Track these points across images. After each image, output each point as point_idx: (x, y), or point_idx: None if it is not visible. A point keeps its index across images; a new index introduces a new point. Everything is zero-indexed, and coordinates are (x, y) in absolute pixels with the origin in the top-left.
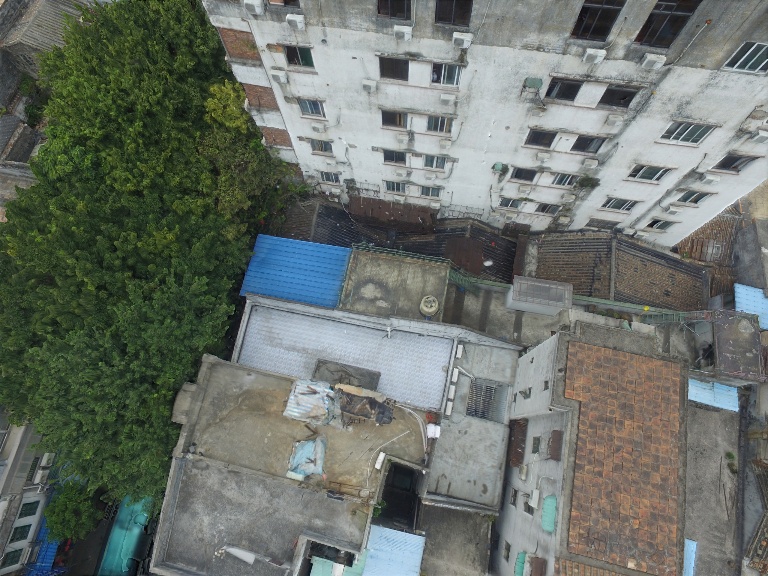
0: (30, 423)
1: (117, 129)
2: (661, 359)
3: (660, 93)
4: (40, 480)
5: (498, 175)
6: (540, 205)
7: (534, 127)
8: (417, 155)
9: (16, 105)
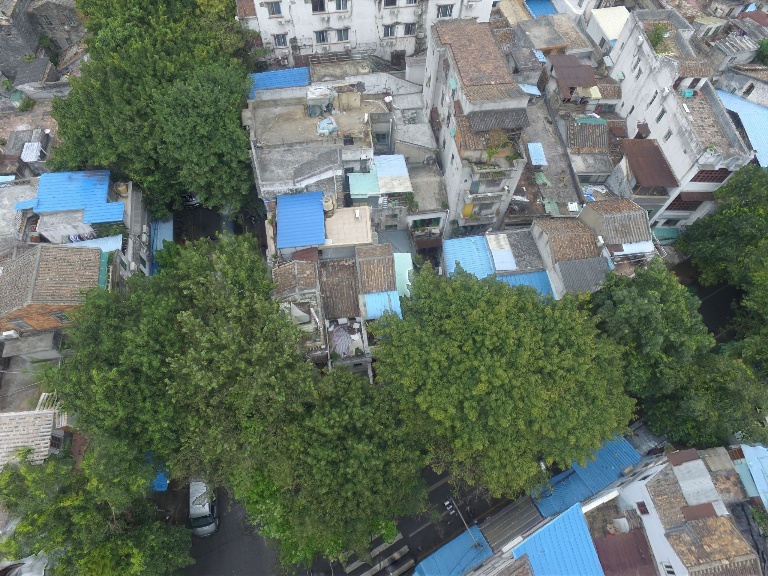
0: (140, 179)
1: (147, 15)
2: None
3: None
4: (146, 239)
5: (377, 4)
6: (406, 29)
7: None
8: (331, 0)
9: (40, 54)
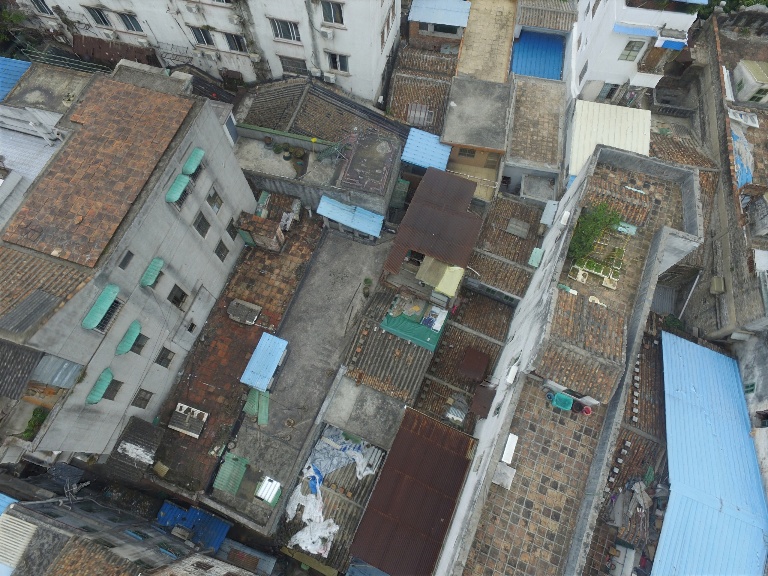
0: None
1: None
2: None
3: None
4: None
5: None
6: (230, 40)
7: None
8: None
9: None
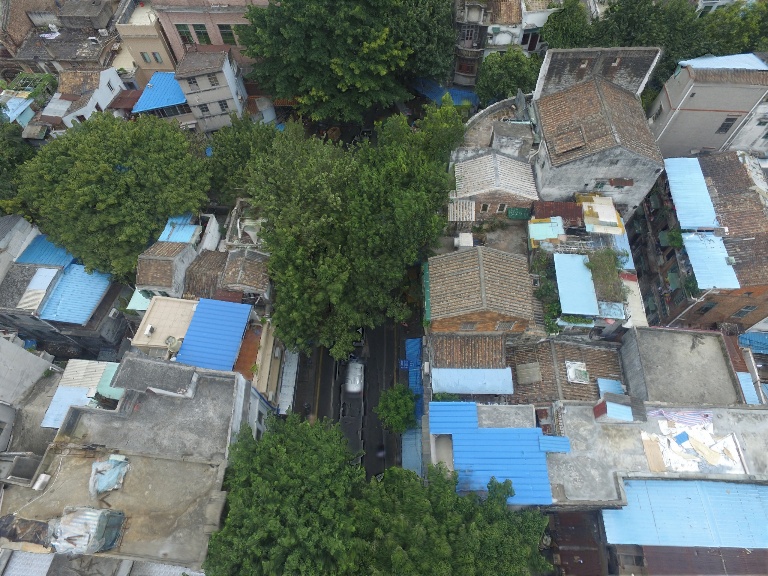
0: None
1: None
2: None
3: None
4: None
5: None
6: None
7: None
8: None
9: None
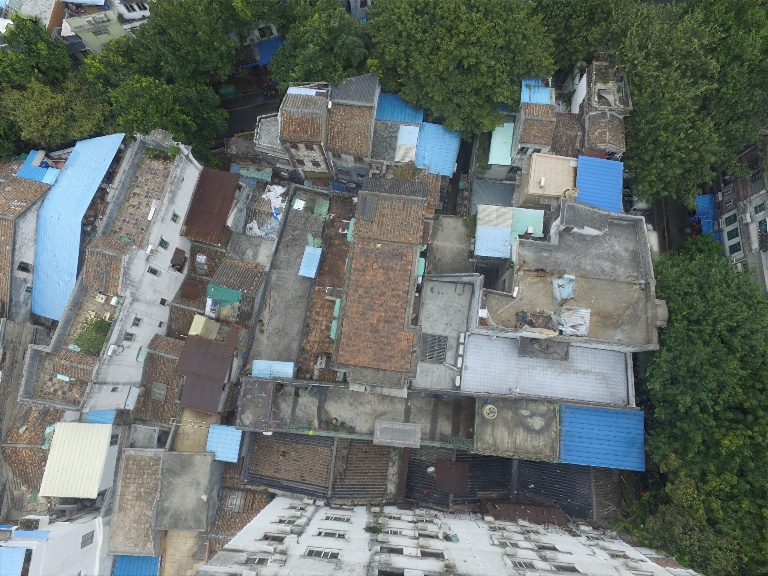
0: None
1: None
2: (349, 365)
3: (361, 575)
4: (737, 266)
5: None
6: None
7: (444, 560)
8: None
9: None
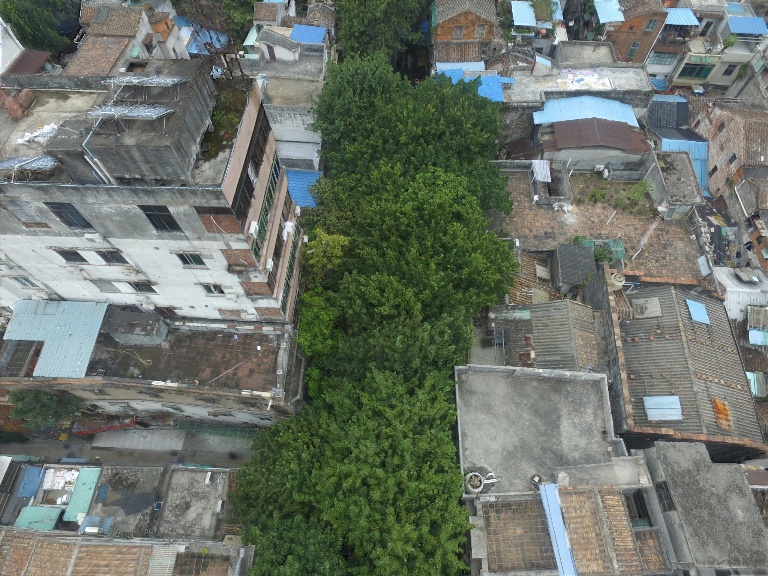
0: None
1: None
2: None
3: None
4: None
5: None
6: None
7: None
8: None
9: None
